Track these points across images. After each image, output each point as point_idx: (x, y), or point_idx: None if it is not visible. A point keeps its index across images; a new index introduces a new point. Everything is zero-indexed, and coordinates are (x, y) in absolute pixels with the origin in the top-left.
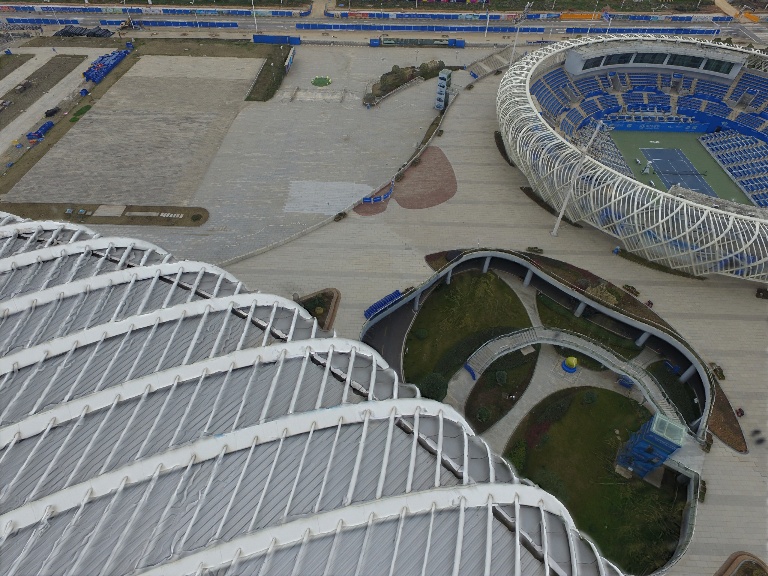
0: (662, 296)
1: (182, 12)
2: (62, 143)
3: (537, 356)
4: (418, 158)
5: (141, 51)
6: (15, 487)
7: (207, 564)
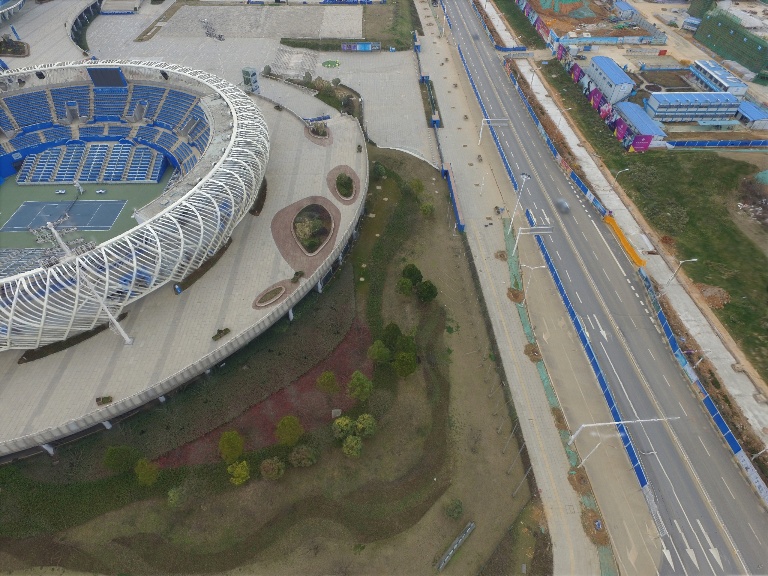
0: None
1: None
2: None
3: None
4: None
5: (371, 5)
6: None
7: None
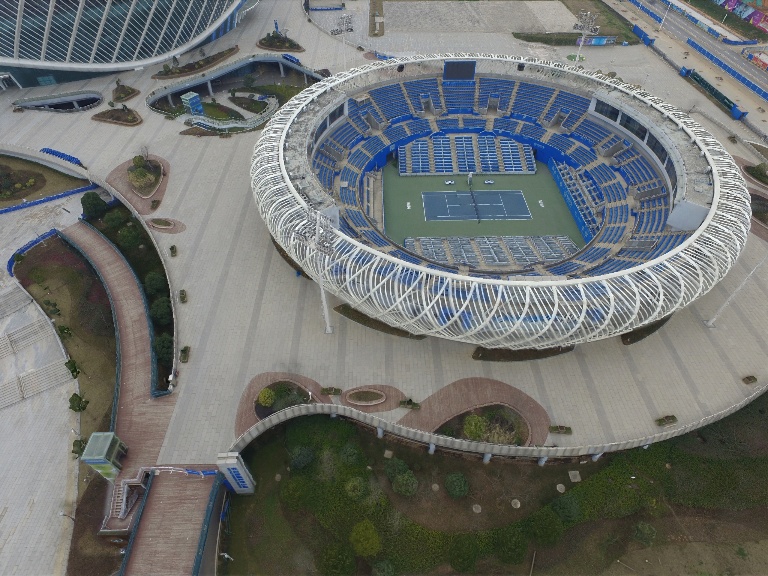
0: None
1: (667, 3)
2: (435, 2)
3: None
4: None
5: None
6: None
7: None
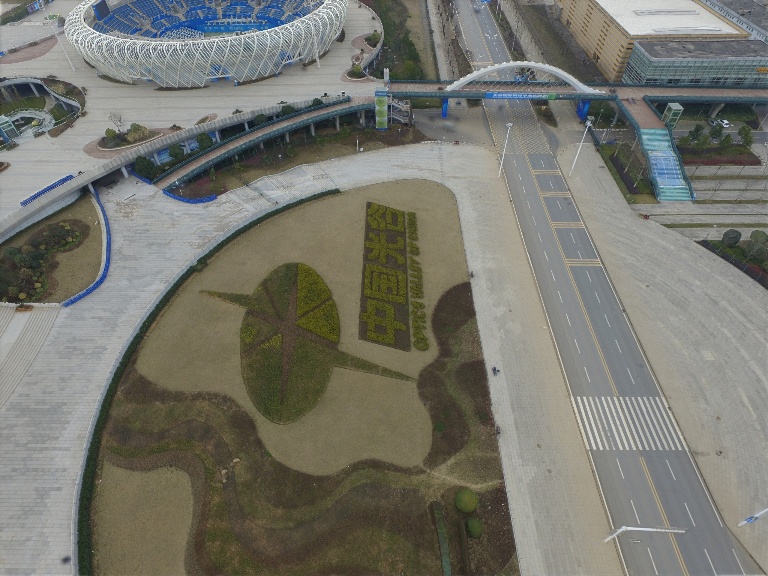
0: (99, 91)
1: None
2: None
3: (24, 125)
4: (37, 42)
5: None
6: None
7: None
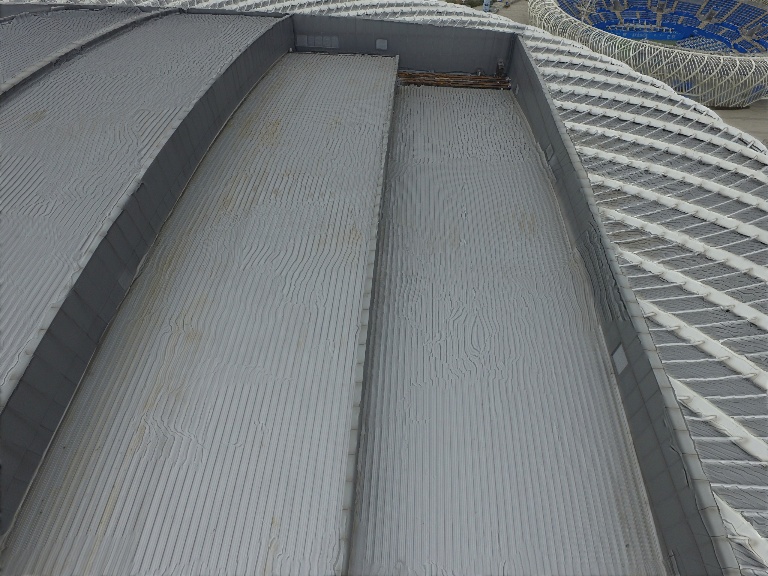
0: None
1: None
2: None
3: None
4: None
5: None
6: (388, 6)
7: (453, 18)
